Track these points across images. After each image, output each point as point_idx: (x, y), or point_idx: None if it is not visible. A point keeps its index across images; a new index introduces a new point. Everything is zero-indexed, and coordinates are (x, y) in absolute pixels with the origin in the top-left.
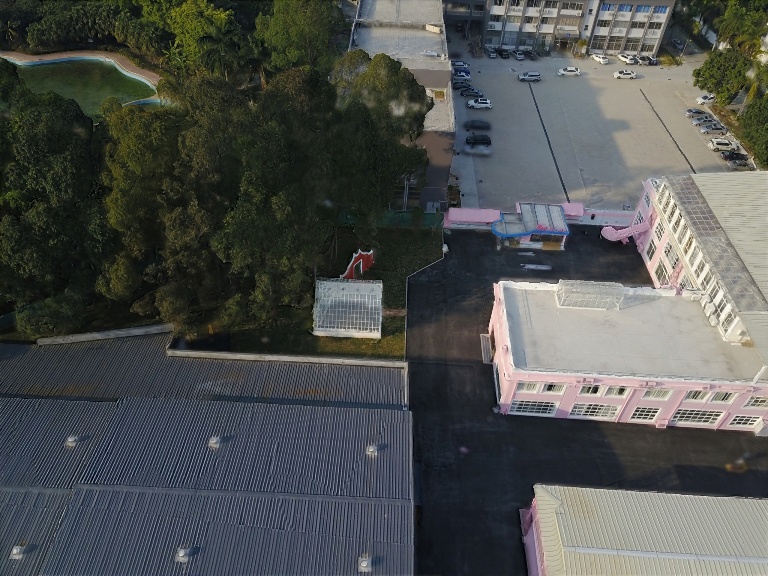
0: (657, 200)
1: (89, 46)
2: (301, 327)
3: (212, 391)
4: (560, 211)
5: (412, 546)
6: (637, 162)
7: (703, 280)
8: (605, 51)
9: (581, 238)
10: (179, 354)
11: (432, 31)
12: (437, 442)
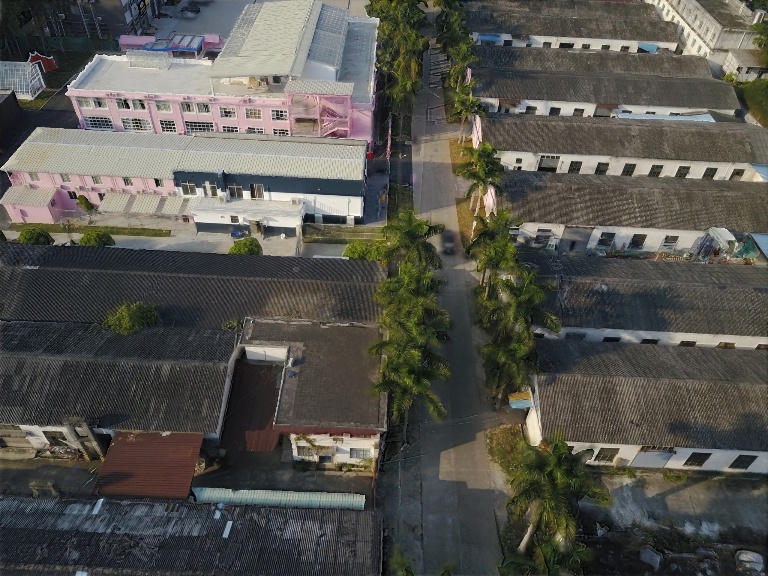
0: None
1: None
2: None
3: None
4: (201, 39)
5: None
6: None
7: None
8: None
9: None
10: None
11: None
12: None
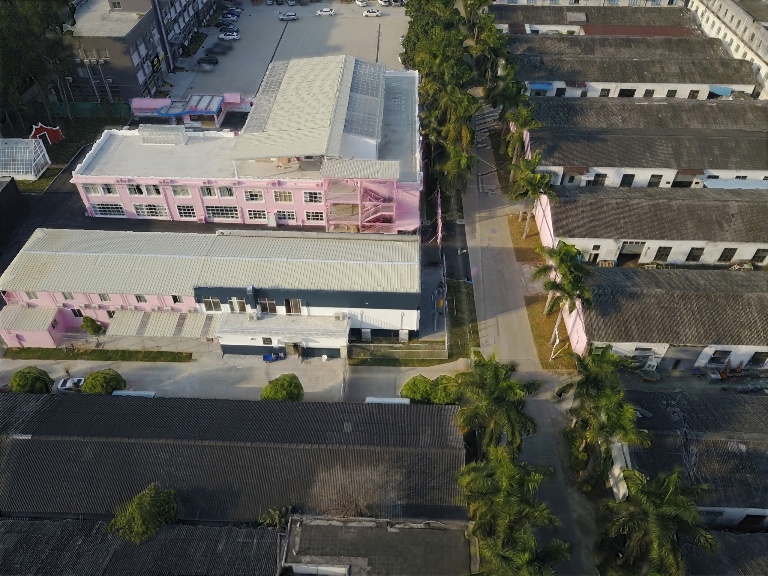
0: None
1: None
2: None
3: None
4: (221, 99)
5: None
6: None
7: None
8: None
9: (239, 120)
10: None
11: None
12: (32, 231)
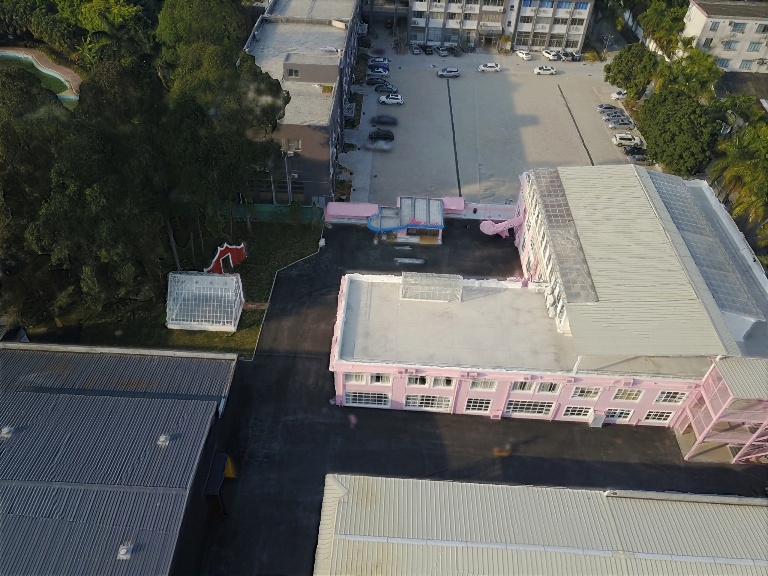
0: (528, 194)
1: (10, 42)
2: (158, 320)
3: (34, 383)
4: (440, 205)
5: (177, 534)
6: (538, 157)
7: (549, 272)
8: (530, 47)
9: (461, 232)
10: (11, 346)
11: (338, 27)
12: (266, 433)
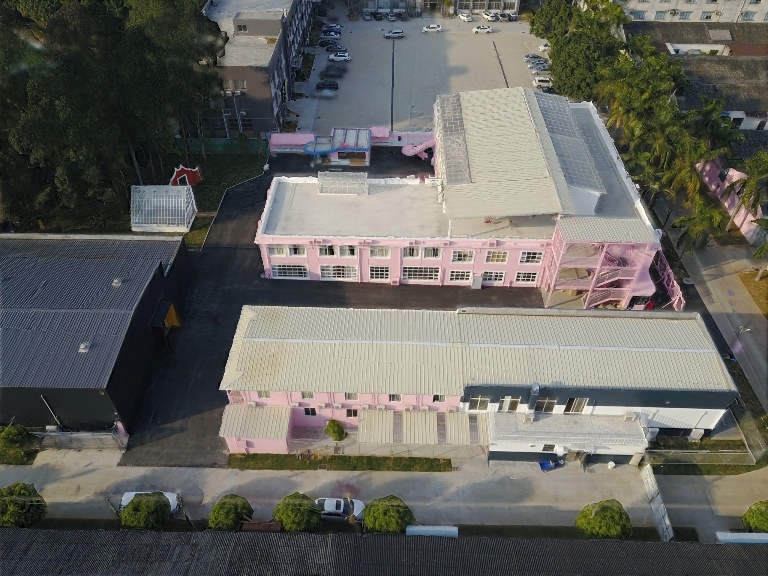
0: (437, 117)
1: None
2: (125, 226)
3: None
4: (368, 134)
5: (123, 336)
6: None
7: None
8: (471, 11)
9: (387, 156)
10: (2, 236)
11: None
12: (207, 298)
